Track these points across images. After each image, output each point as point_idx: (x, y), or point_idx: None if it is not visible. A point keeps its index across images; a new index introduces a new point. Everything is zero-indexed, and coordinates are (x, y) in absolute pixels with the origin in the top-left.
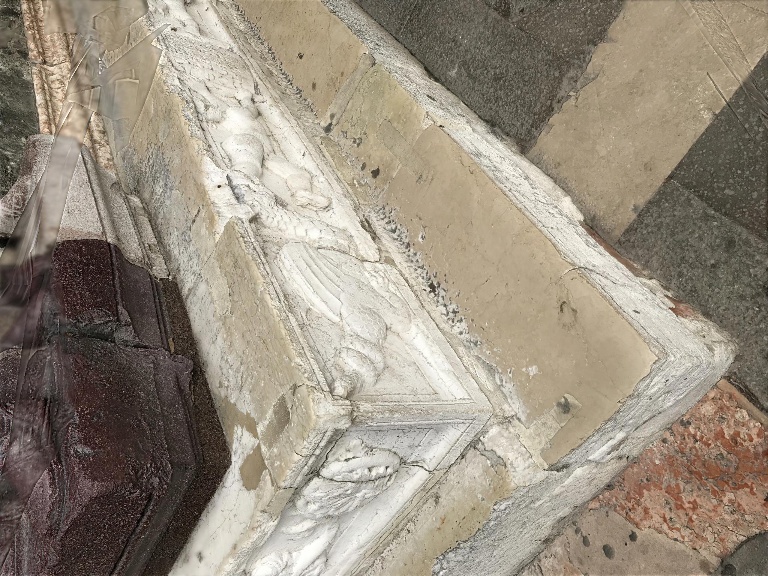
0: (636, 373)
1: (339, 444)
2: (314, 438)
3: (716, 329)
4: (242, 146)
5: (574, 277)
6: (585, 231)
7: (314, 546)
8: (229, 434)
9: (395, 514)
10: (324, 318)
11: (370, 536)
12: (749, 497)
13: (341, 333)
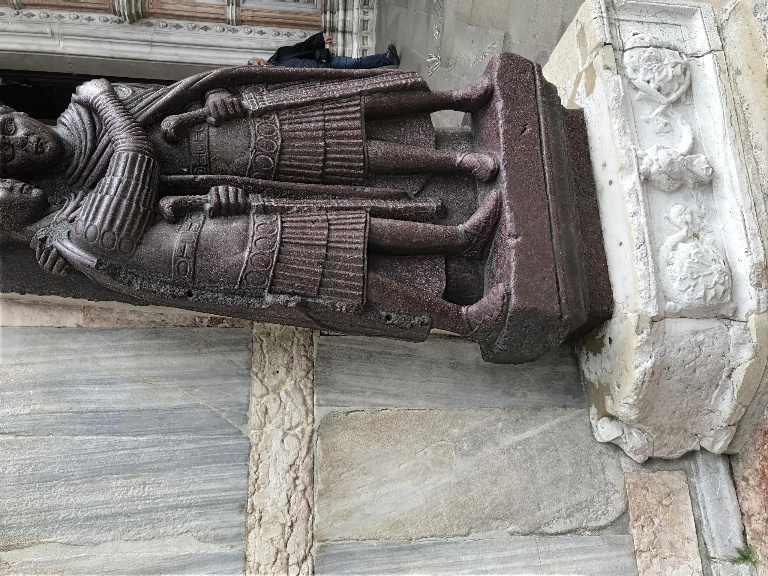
0: None
1: (622, 30)
2: (595, 6)
3: None
4: None
5: None
6: None
7: (683, 142)
8: None
9: (720, 96)
10: None
11: (720, 123)
12: None
13: None
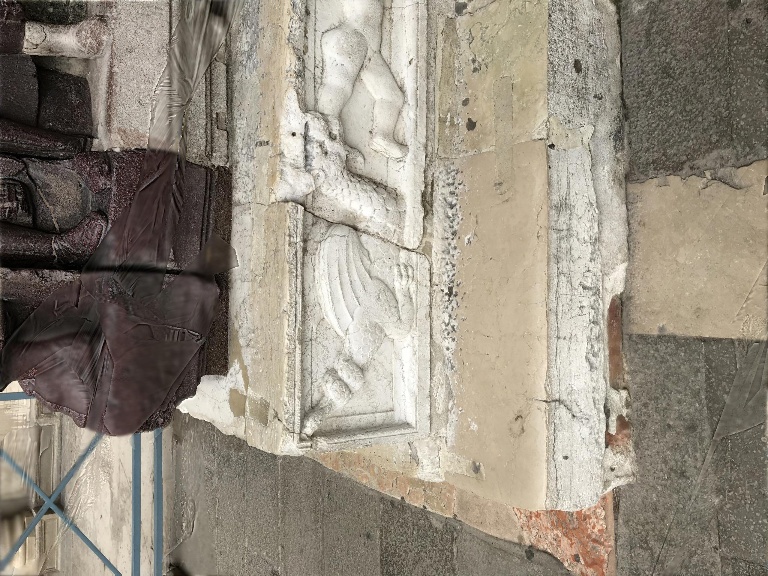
0: (526, 505)
1: None
2: None
3: (632, 461)
4: (341, 58)
5: (541, 409)
6: (602, 328)
7: None
8: (231, 357)
9: None
10: (332, 330)
11: None
12: (568, 545)
13: (340, 347)
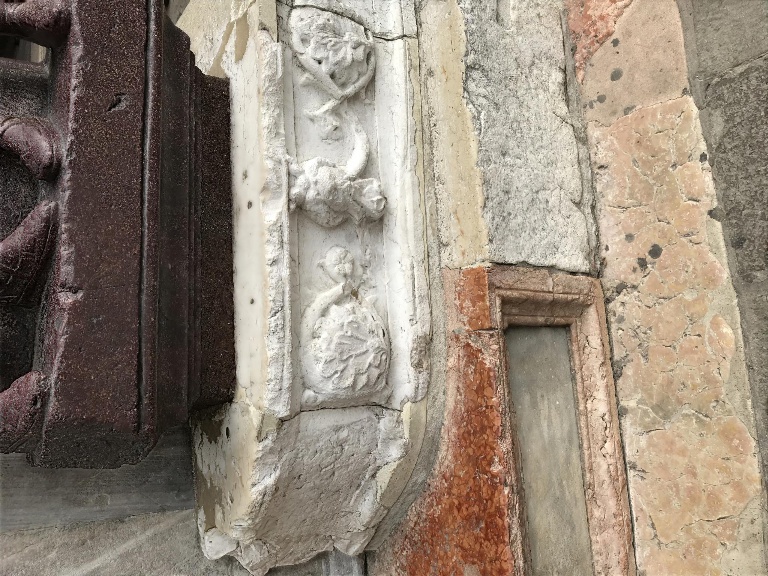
0: None
1: None
2: None
3: None
4: None
5: None
6: None
7: (355, 157)
8: (219, 76)
9: (406, 100)
10: None
11: (402, 138)
12: None
13: None
